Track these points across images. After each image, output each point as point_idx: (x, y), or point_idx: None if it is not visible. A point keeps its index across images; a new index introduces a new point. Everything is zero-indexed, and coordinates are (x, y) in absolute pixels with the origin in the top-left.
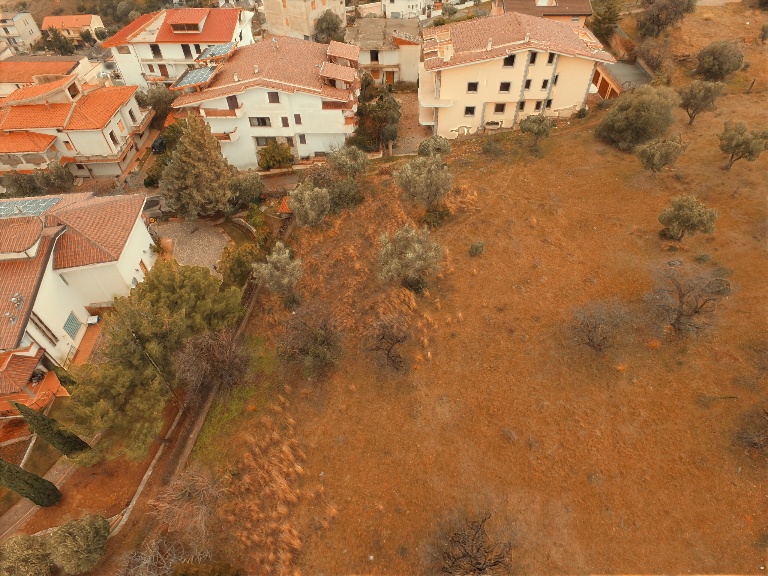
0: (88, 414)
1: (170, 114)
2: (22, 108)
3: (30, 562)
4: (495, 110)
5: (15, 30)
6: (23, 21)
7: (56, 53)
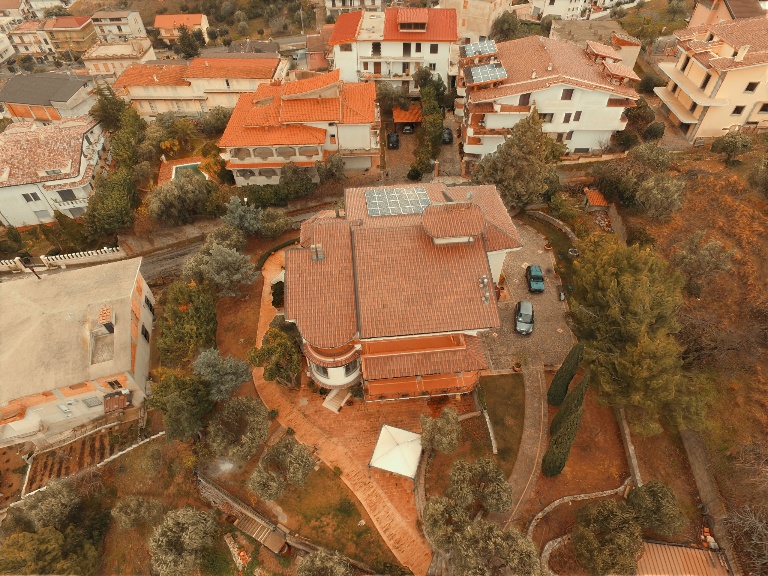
0: (652, 387)
1: (394, 110)
2: (293, 102)
3: (631, 524)
4: (760, 110)
5: (128, 28)
6: (134, 19)
7: (250, 50)
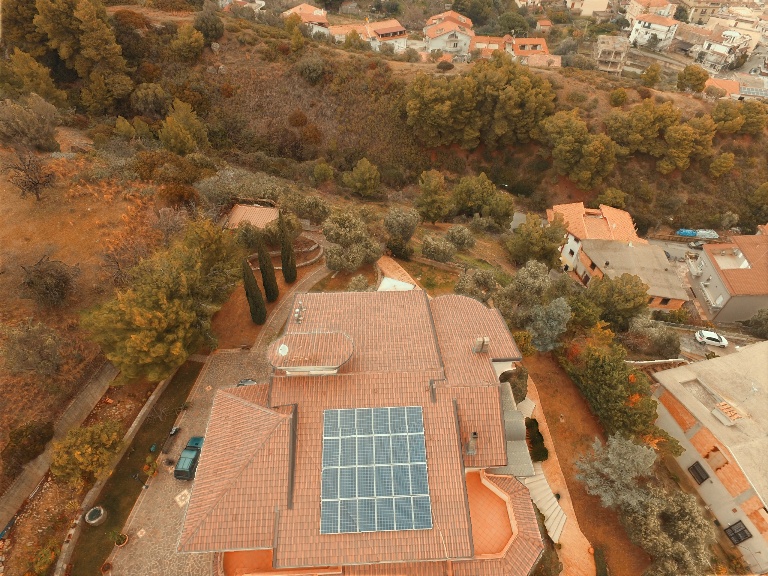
0: None
1: None
2: None
3: None
4: None
5: None
6: None
7: None
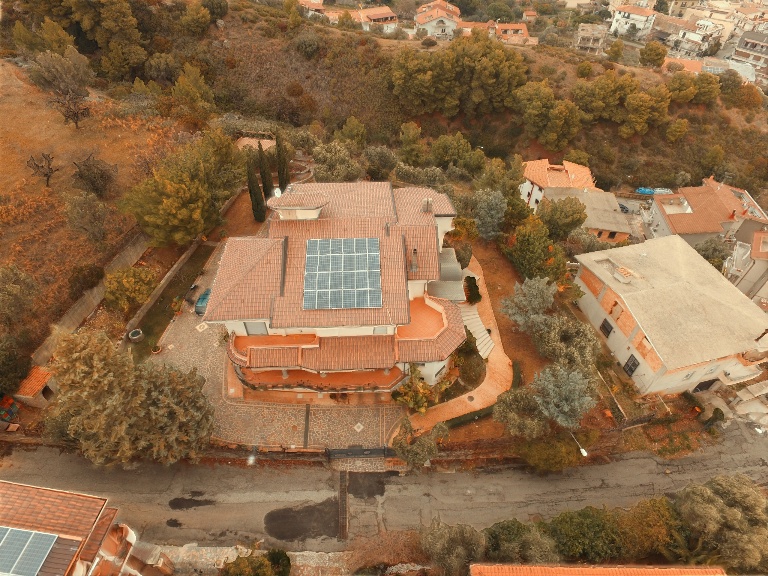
0: None
1: None
2: None
3: None
4: None
5: None
6: None
7: None
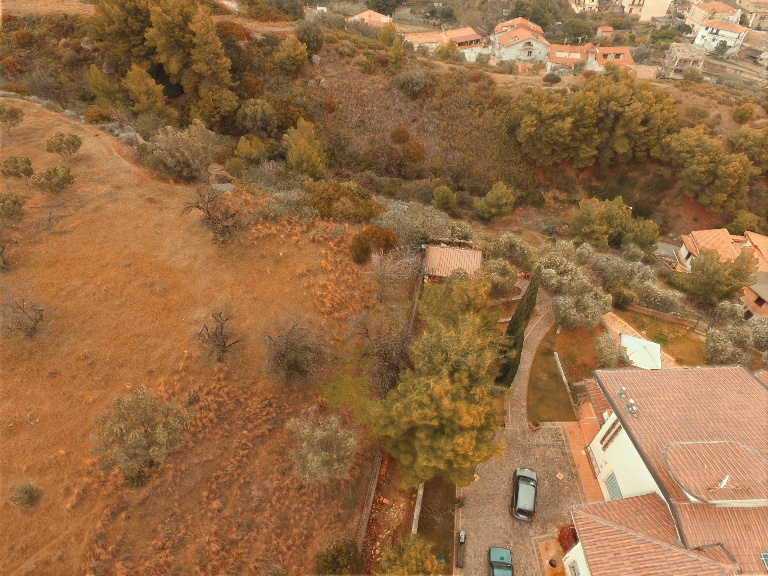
0: None
1: None
2: None
3: None
4: None
5: None
6: None
7: None
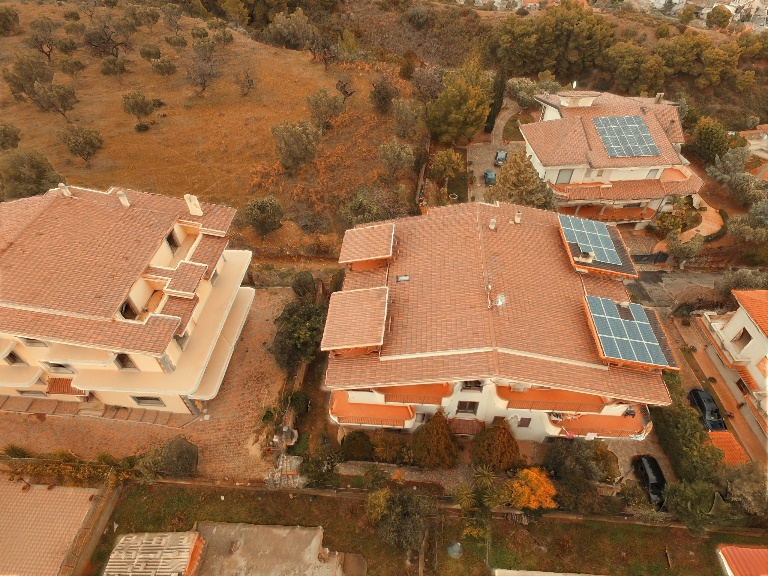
0: None
1: None
2: None
3: None
4: None
5: None
6: None
7: None
